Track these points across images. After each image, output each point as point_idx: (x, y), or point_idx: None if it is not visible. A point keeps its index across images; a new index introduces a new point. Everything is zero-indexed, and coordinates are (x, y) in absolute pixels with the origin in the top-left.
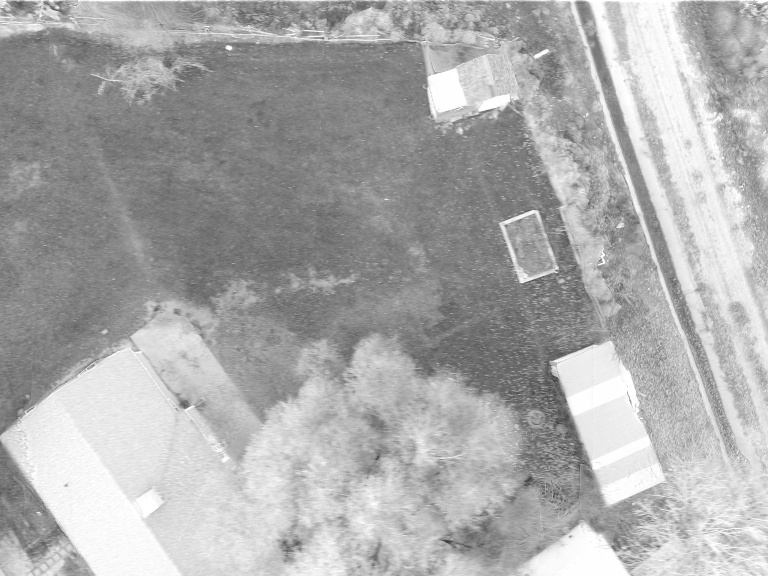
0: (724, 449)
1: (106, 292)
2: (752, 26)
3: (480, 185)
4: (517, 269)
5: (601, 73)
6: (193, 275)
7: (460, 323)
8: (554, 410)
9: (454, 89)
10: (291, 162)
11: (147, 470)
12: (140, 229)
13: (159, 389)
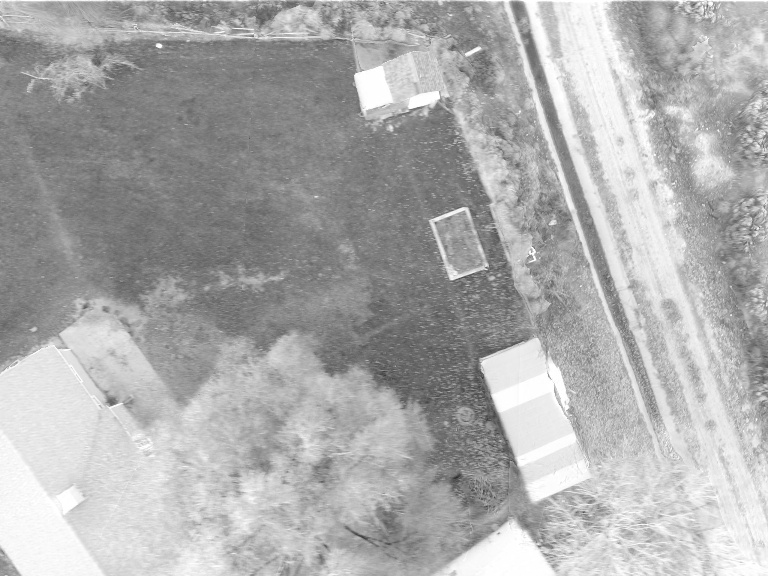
0: (657, 446)
1: (35, 290)
2: (687, 23)
3: (410, 182)
4: (447, 266)
5: (535, 70)
6: (122, 273)
7: (390, 320)
8: (484, 407)
9: (380, 86)
10: (221, 160)
11: (69, 467)
12: (69, 227)
13: (82, 386)
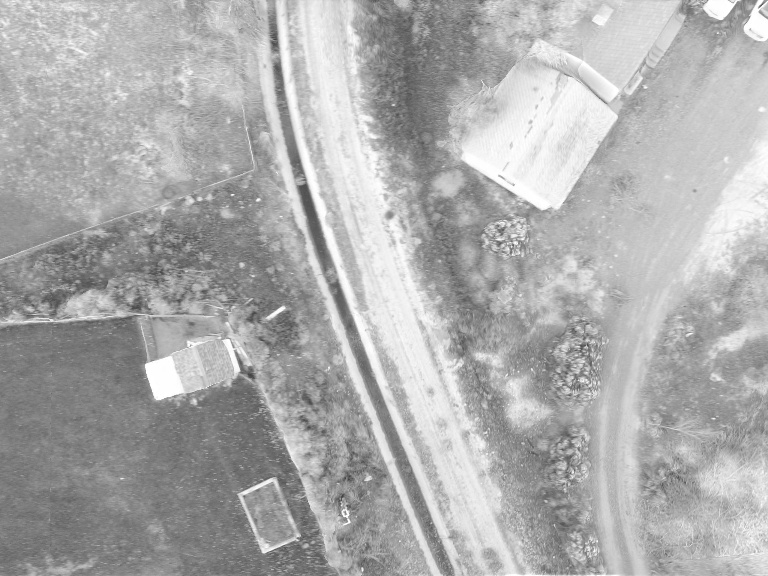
0: None
1: None
2: (496, 260)
3: (217, 456)
4: (258, 539)
5: (346, 319)
6: None
7: None
8: None
9: (171, 376)
10: (22, 449)
11: None
12: None
13: None
